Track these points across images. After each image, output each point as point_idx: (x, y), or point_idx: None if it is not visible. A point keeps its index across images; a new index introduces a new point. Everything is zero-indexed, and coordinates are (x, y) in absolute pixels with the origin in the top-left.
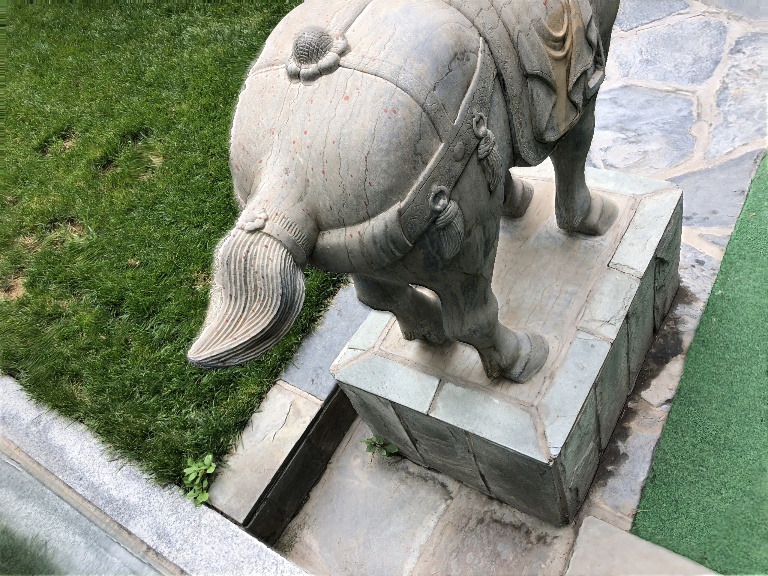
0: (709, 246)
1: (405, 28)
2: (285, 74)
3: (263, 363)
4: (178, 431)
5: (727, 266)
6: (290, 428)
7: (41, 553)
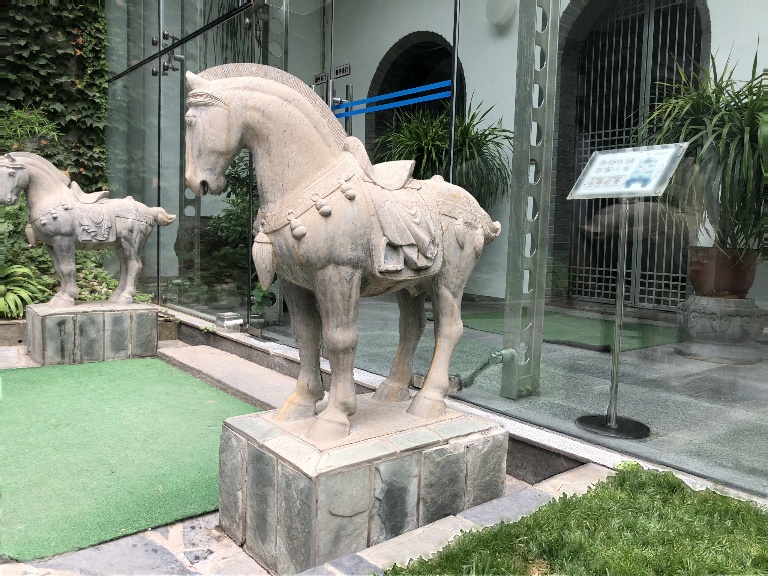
0: (174, 532)
1: None
2: None
3: (585, 500)
4: (665, 495)
5: (187, 514)
6: (559, 482)
7: (765, 484)
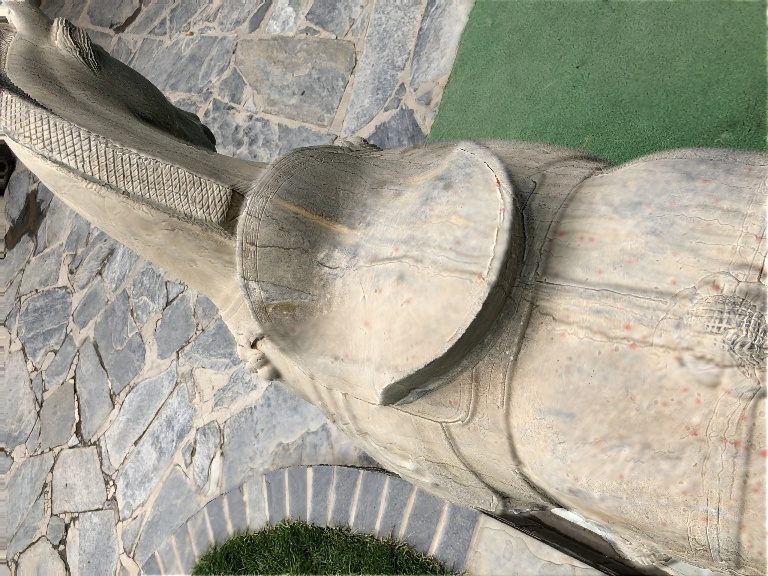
0: None
1: (662, 203)
2: (767, 393)
3: None
4: None
5: None
6: None
7: None
